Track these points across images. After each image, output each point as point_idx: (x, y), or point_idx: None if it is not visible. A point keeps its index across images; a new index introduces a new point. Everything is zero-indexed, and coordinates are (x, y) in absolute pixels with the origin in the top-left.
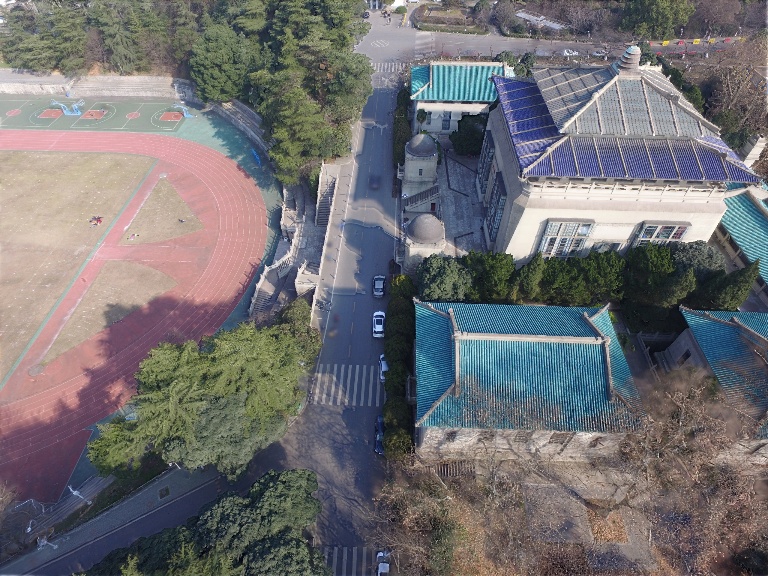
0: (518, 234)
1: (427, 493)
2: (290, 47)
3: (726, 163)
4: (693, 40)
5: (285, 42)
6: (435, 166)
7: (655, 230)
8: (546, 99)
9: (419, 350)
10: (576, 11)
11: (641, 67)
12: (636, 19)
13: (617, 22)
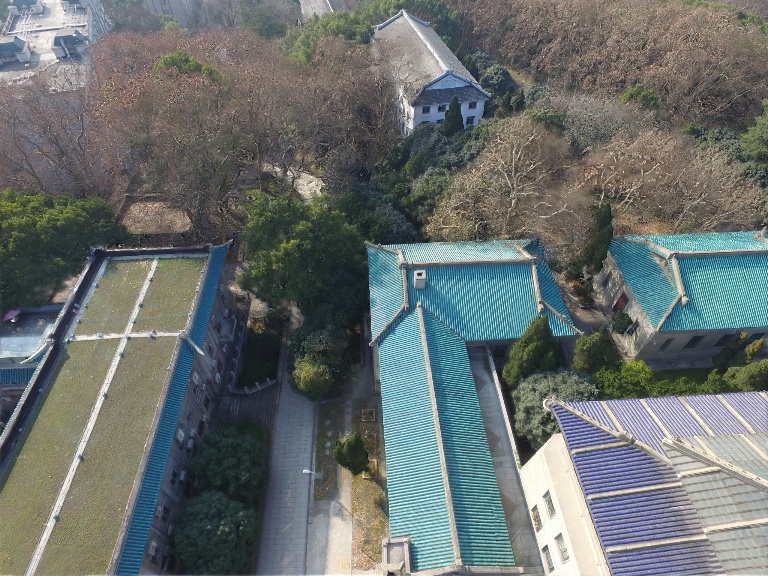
0: None
1: None
2: None
3: (614, 429)
4: None
5: None
6: None
7: None
8: None
9: None
10: None
11: None
12: None
13: None
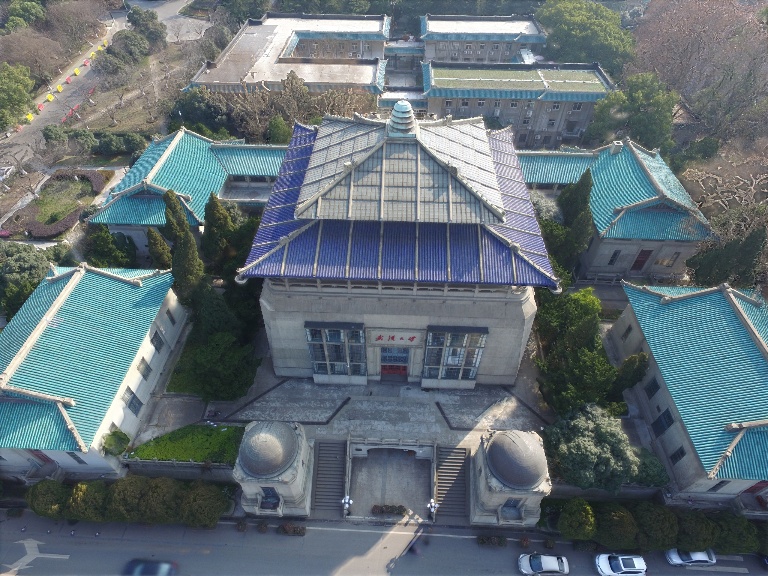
0: None
1: None
2: None
3: None
4: (43, 98)
5: None
6: None
7: None
8: (410, 219)
9: None
10: None
11: None
12: None
13: None
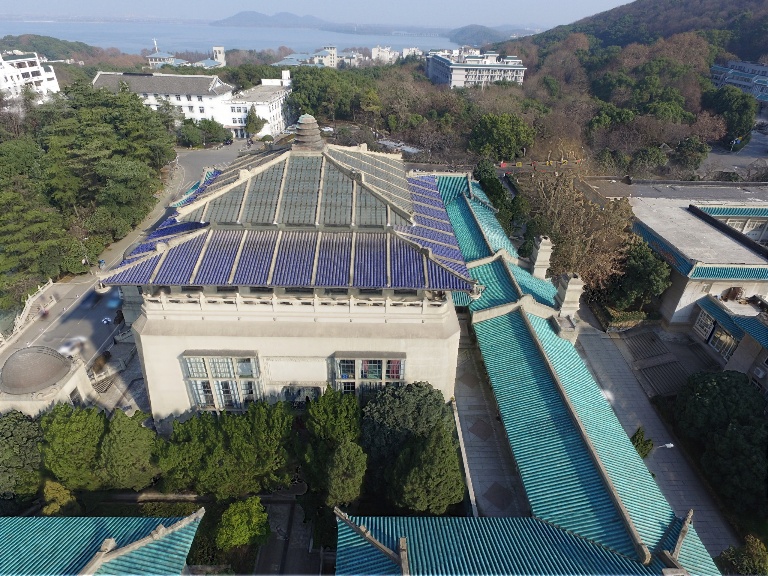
0: (154, 376)
1: None
2: (54, 155)
3: (430, 263)
4: (547, 162)
5: (49, 150)
6: None
7: (354, 366)
8: None
9: None
10: (427, 136)
11: (346, 147)
12: (482, 141)
13: (467, 145)
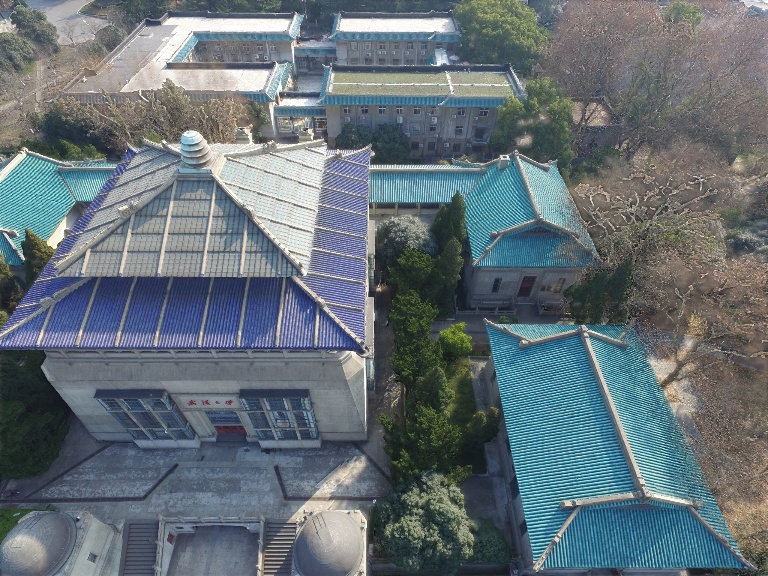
0: None
1: (755, 563)
2: None
3: (346, 159)
4: None
5: None
6: (95, 521)
7: None
8: (193, 273)
9: (630, 562)
10: None
11: None
12: None
13: None
